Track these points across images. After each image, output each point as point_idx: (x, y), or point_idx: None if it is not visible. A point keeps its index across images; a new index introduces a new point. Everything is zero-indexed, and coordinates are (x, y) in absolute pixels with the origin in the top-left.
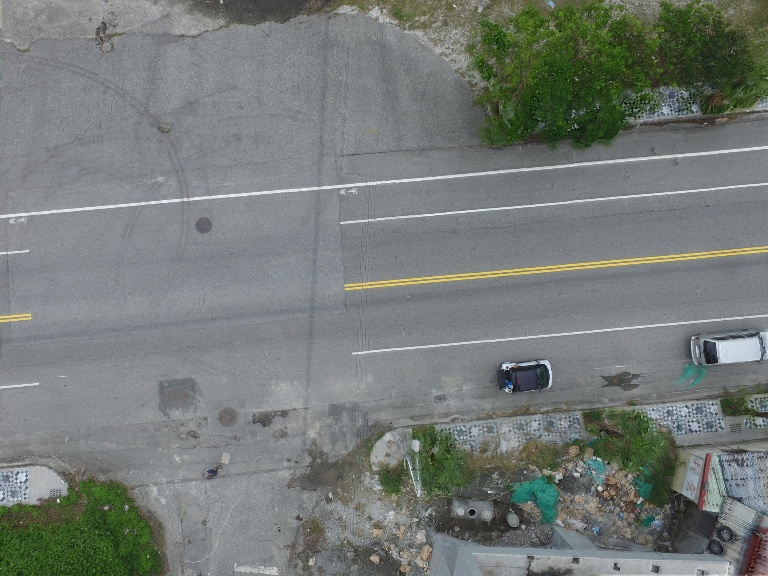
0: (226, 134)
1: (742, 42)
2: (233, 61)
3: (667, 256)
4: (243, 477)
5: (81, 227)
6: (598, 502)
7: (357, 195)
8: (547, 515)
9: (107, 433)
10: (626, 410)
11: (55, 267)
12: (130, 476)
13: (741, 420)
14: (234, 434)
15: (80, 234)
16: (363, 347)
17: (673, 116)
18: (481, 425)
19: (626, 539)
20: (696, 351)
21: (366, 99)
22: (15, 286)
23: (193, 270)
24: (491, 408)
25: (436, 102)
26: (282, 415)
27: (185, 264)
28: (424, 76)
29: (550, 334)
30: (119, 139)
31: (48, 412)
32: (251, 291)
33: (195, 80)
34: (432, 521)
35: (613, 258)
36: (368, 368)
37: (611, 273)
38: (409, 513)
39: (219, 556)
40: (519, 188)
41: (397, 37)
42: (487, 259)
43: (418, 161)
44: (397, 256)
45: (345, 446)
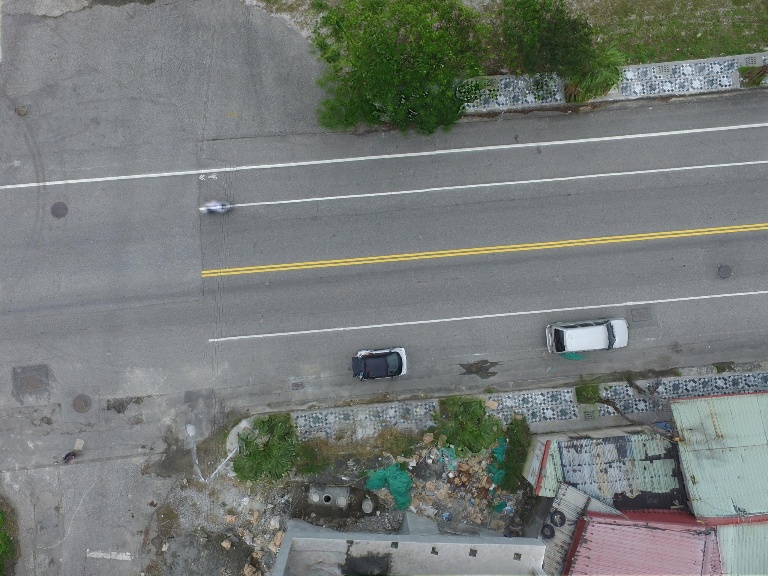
0: (85, 117)
1: (609, 30)
2: (95, 43)
3: (527, 245)
4: (97, 463)
5: None
6: (449, 488)
7: (217, 181)
8: (398, 501)
9: None
10: (482, 398)
11: None
12: None
13: (595, 408)
14: (88, 421)
15: None
16: (219, 334)
17: (537, 104)
18: (338, 412)
19: (476, 524)
20: (549, 339)
21: (230, 83)
22: None
23: (48, 255)
24: (349, 395)
25: (300, 87)
26: (137, 402)
27: (40, 249)
28: (289, 60)
29: (408, 322)
30: None
31: None
32: (107, 277)
33: (54, 62)
34: (289, 507)
35: (473, 246)
36: (224, 355)
37: (470, 261)
38: (264, 499)
39: (71, 542)
40: (381, 175)
41: (263, 20)
42: (347, 246)
43: (280, 147)
44: (256, 243)
45: (201, 433)
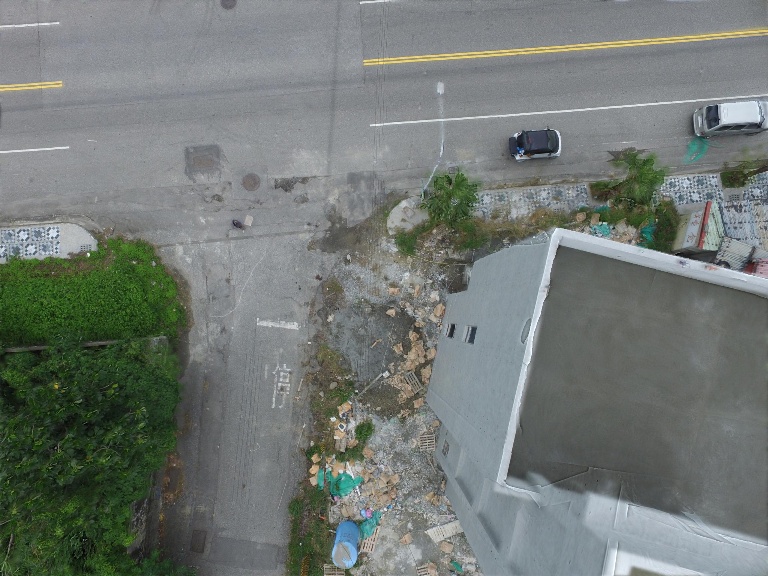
0: None
1: None
2: None
3: (672, 38)
4: (265, 239)
5: (110, 1)
6: None
7: None
8: None
9: (135, 195)
10: None
11: (85, 37)
12: (157, 236)
13: (740, 192)
14: (257, 198)
15: (109, 7)
16: (381, 118)
17: None
18: (493, 194)
19: None
20: (698, 122)
21: None
22: (46, 55)
23: (218, 44)
24: (502, 179)
25: None
26: (303, 182)
27: (210, 38)
28: None
29: (560, 110)
30: None
31: (78, 174)
32: (274, 64)
33: None
34: (445, 286)
35: (621, 39)
36: (386, 138)
37: (619, 53)
38: (423, 275)
39: (242, 311)
40: None
41: None
42: (500, 39)
43: None
44: (414, 35)
45: (363, 212)
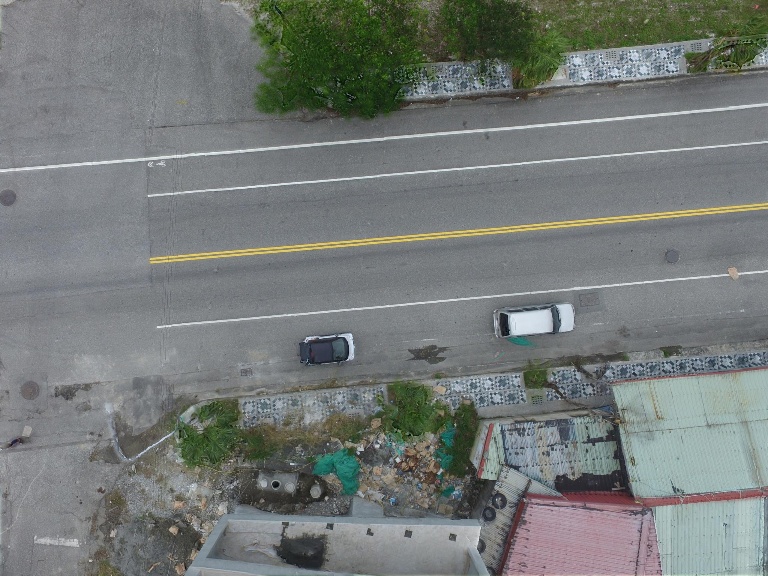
0: (33, 105)
1: (558, 16)
2: (44, 31)
3: (474, 230)
4: (45, 450)
5: None
6: (395, 473)
7: (165, 168)
8: (346, 486)
9: None
10: (430, 383)
11: None
12: None
13: (543, 392)
14: (36, 407)
15: None
16: (167, 320)
17: (485, 90)
18: (286, 398)
19: (423, 509)
20: (496, 324)
21: (179, 71)
22: None
23: None
24: (297, 381)
25: (249, 74)
26: (86, 388)
27: None
28: (238, 48)
29: (357, 308)
30: None
31: None
32: (55, 264)
33: (3, 50)
34: (238, 493)
35: (421, 232)
36: (172, 341)
37: (419, 247)
38: (212, 485)
39: (19, 529)
40: (329, 162)
41: (213, 8)
42: (295, 233)
43: (228, 134)
44: (205, 229)
45: (149, 419)
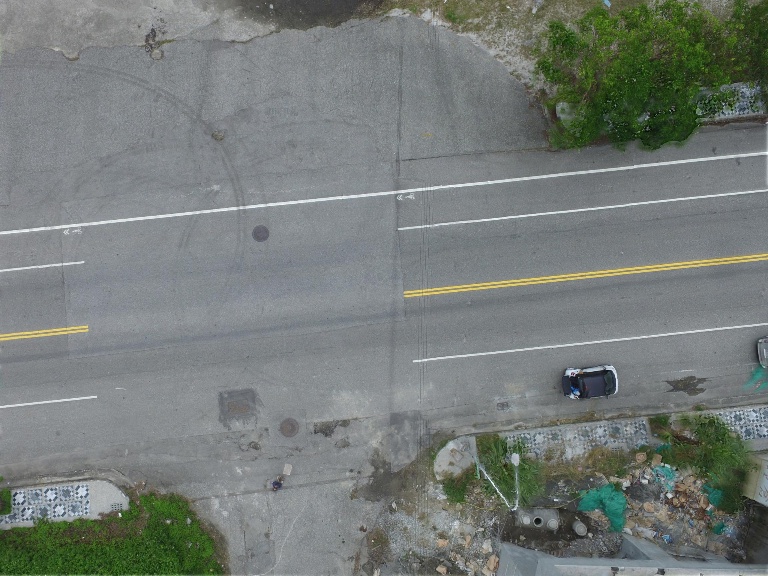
0: (280, 141)
1: None
2: (285, 67)
3: (731, 258)
4: (305, 488)
5: (136, 237)
6: (668, 509)
7: (415, 201)
8: (616, 523)
9: (167, 445)
10: (692, 415)
11: (111, 278)
12: (191, 489)
13: None
14: (295, 445)
15: (136, 244)
16: (424, 355)
17: (734, 116)
18: (545, 432)
19: (697, 546)
20: (764, 354)
21: (421, 103)
22: (71, 298)
23: (251, 279)
24: (555, 415)
25: (492, 105)
26: (343, 425)
27: (242, 273)
28: (479, 79)
29: (613, 339)
30: (173, 147)
31: (107, 425)
32: (310, 299)
33: (247, 86)
34: (497, 530)
35: (676, 261)
36: (430, 376)
37: (674, 276)
38: (474, 523)
39: (283, 569)
40: (579, 191)
41: (450, 40)
42: (548, 264)
43: (475, 165)
44: (456, 262)
45: (408, 455)
